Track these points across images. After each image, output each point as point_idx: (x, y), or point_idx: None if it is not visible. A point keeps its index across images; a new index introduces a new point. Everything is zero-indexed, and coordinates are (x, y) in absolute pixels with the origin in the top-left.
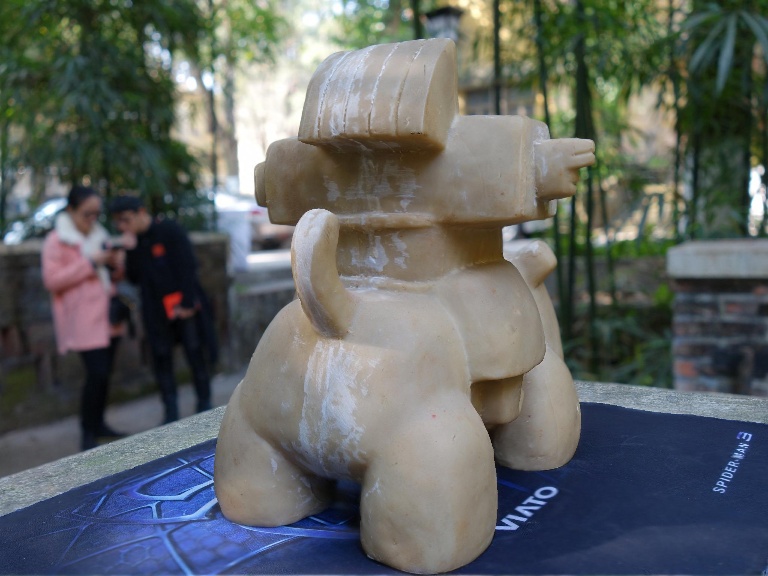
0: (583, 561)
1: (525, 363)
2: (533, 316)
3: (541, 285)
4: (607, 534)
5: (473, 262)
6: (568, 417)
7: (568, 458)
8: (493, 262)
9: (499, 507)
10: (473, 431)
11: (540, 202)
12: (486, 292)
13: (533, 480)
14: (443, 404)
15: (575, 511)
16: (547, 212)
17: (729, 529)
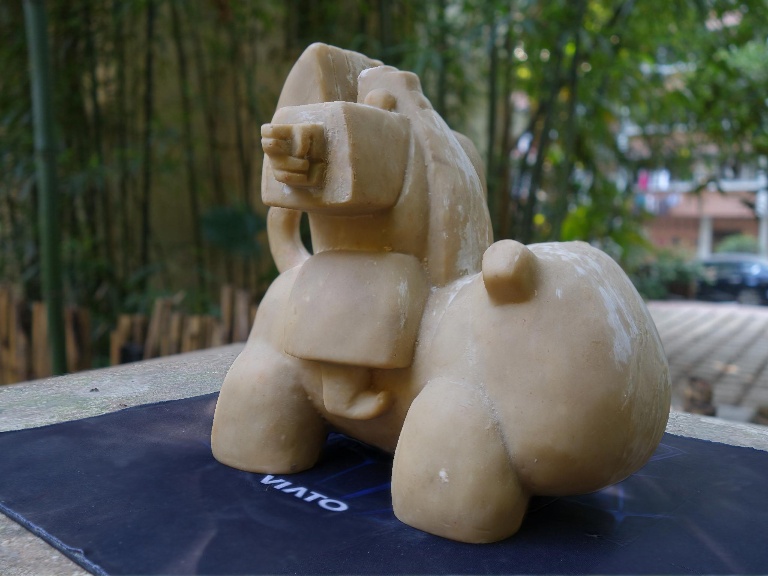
0: (182, 492)
1: (297, 347)
2: (330, 310)
3: (515, 305)
4: (217, 510)
5: (334, 247)
6: (412, 468)
7: (414, 522)
8: (347, 250)
9: (310, 482)
10: (241, 373)
11: (300, 189)
12: (300, 273)
13: (369, 503)
14: (252, 348)
15: (278, 509)
16: (320, 199)
17: (174, 570)
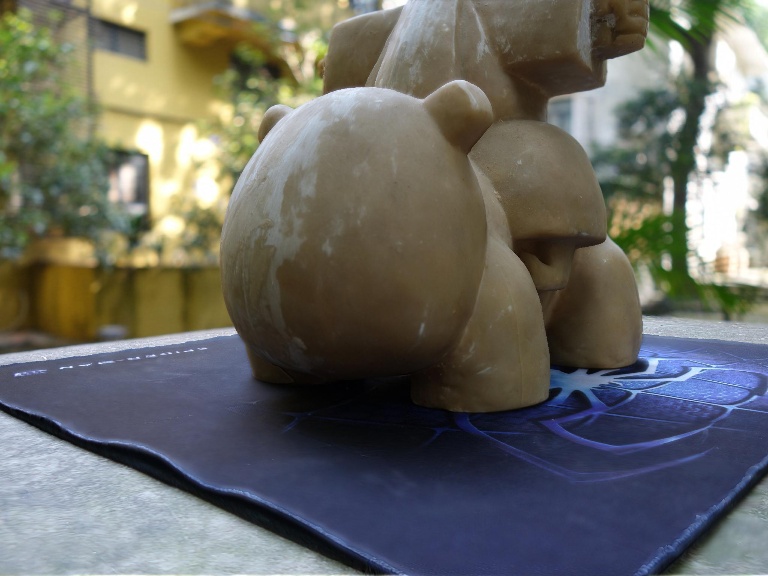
0: None
1: None
2: None
3: None
4: None
5: None
6: None
7: None
8: None
9: None
10: None
11: None
12: None
13: None
14: None
15: None
16: None
17: None
